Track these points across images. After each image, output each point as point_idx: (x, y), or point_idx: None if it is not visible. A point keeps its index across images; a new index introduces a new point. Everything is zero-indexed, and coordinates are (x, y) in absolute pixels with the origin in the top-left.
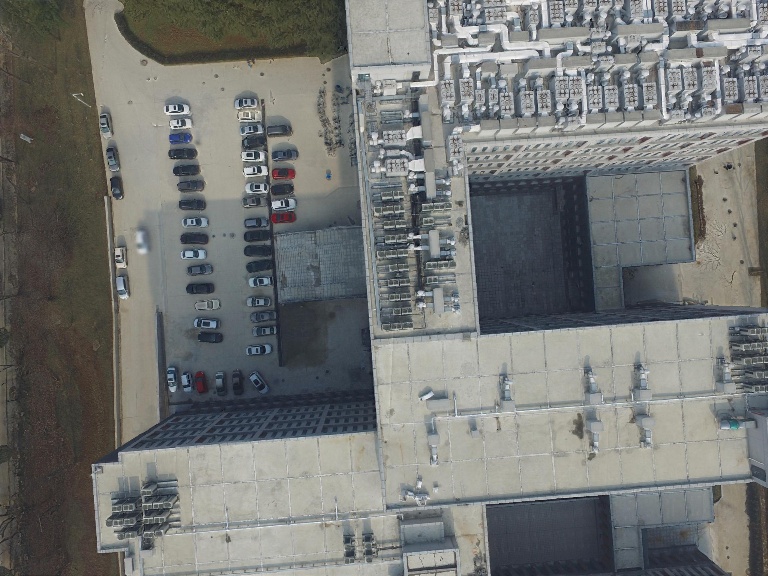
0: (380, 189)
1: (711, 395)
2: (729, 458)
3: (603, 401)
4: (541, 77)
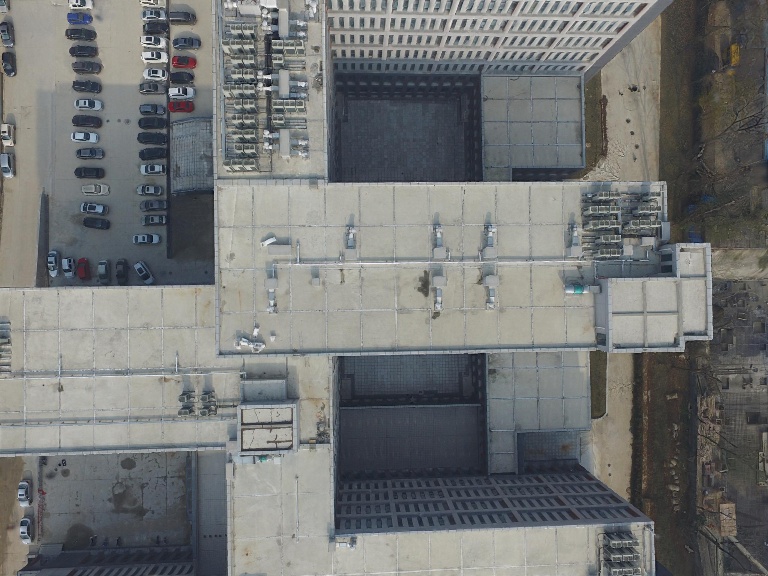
0: None
1: (560, 260)
2: (575, 326)
3: (450, 259)
4: None
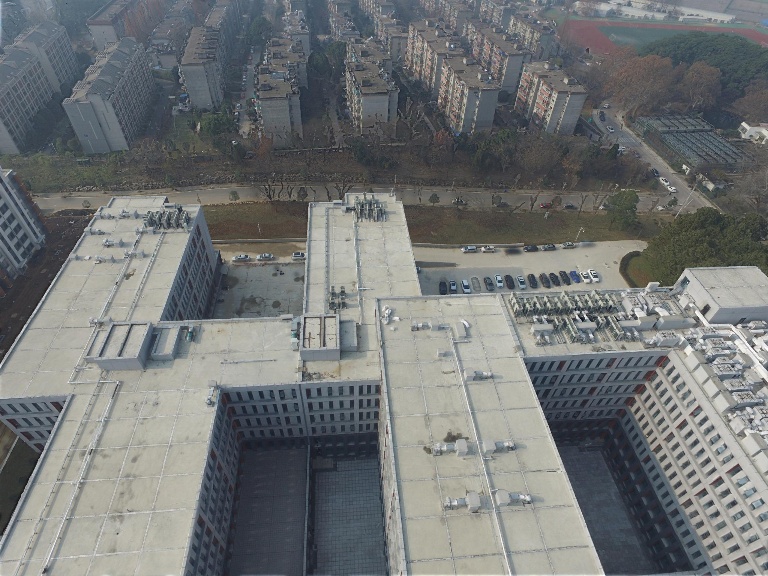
0: None
1: None
2: None
3: (485, 461)
4: (765, 405)
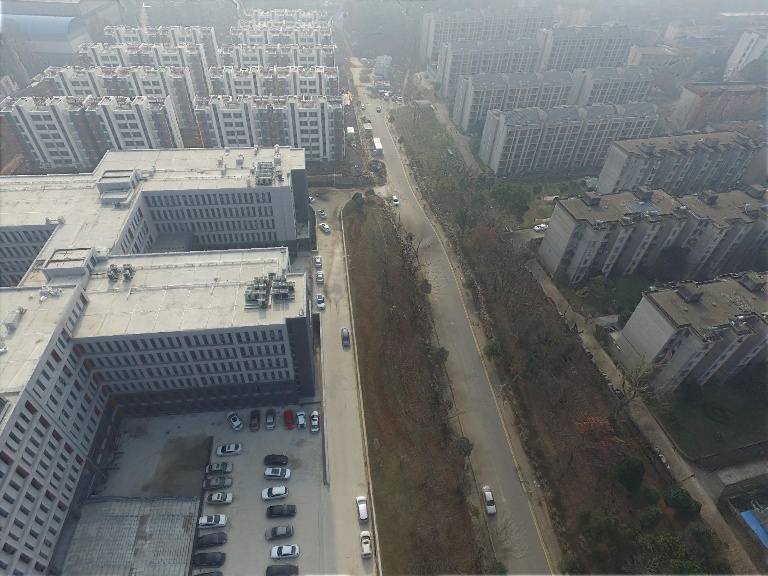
0: None
1: None
2: None
3: None
4: None
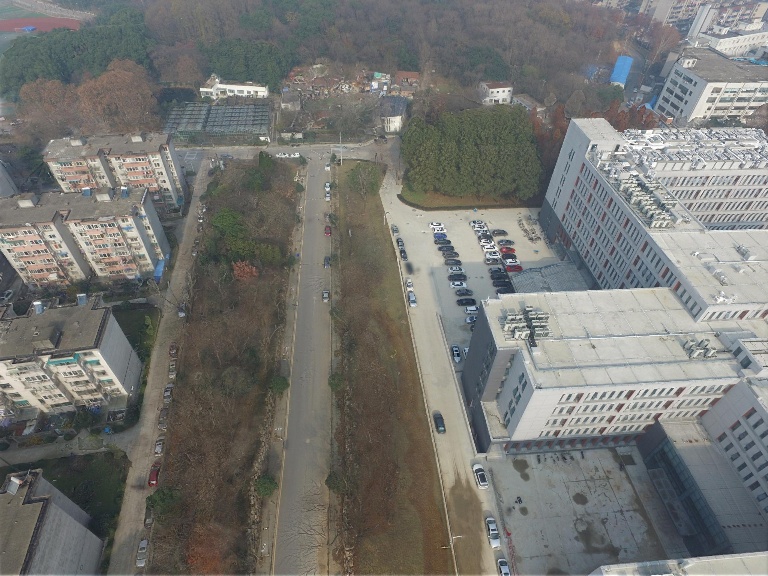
0: (616, 184)
1: None
2: None
3: None
4: None
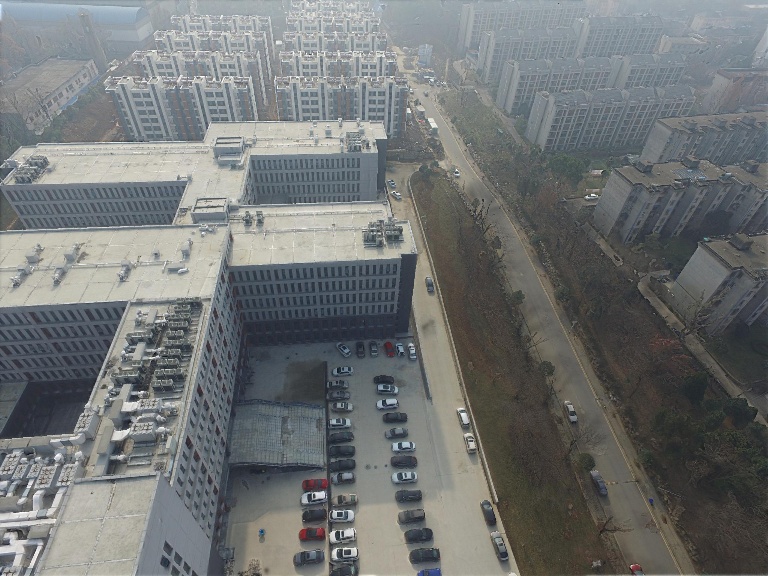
0: None
1: None
2: None
3: None
4: None
